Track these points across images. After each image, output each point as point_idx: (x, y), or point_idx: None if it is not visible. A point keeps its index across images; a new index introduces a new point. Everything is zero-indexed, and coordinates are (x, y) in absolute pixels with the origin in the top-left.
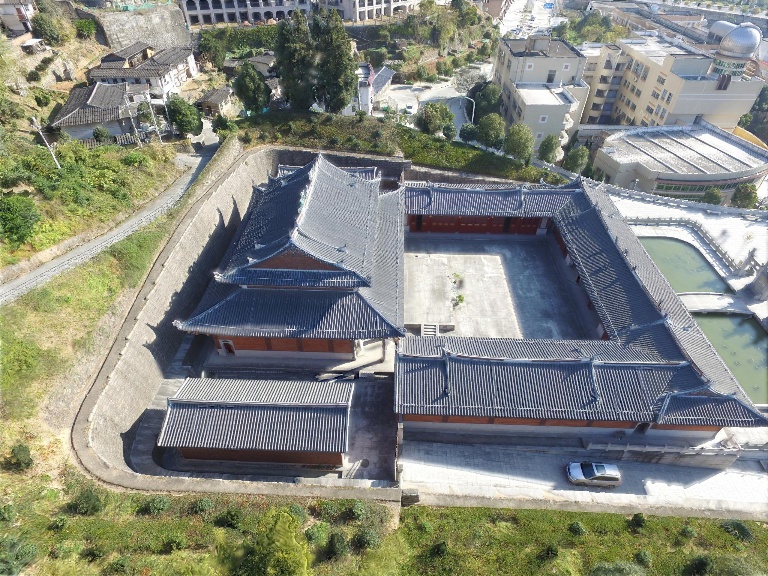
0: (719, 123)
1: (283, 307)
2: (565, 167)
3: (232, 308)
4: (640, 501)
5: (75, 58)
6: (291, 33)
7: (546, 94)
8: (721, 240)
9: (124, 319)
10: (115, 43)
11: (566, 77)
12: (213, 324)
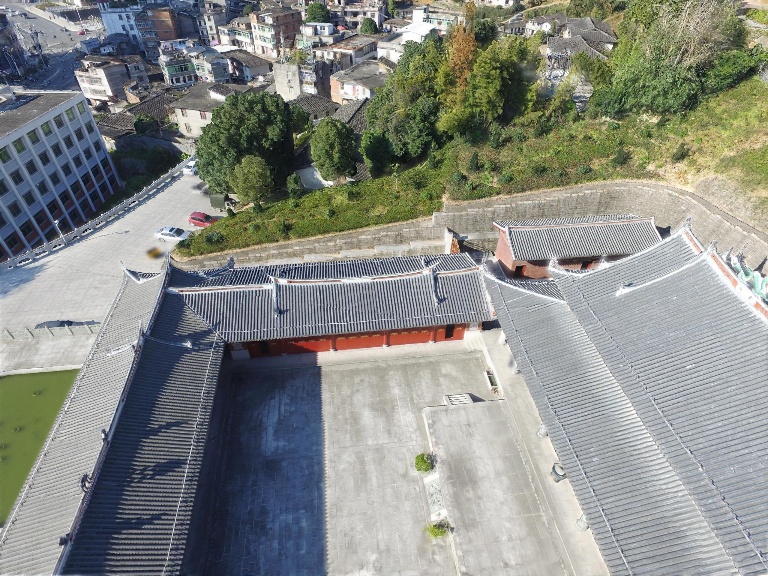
0: None
1: None
2: None
3: None
4: (266, 264)
5: None
6: None
7: None
8: None
9: None
10: None
11: None
12: None
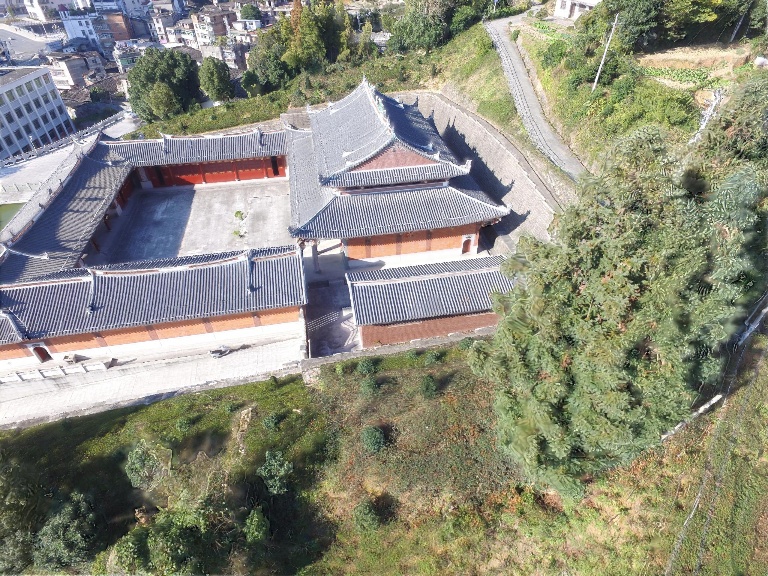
0: None
1: None
2: None
3: None
4: None
5: None
6: None
7: None
8: None
9: None
10: None
11: None
12: None
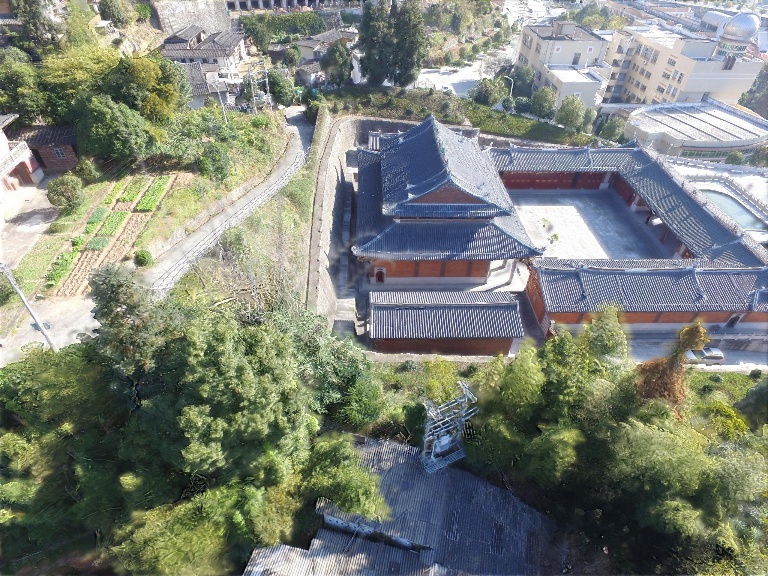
0: (723, 100)
1: (434, 237)
2: (602, 137)
3: (391, 238)
4: None
5: (137, 40)
6: (375, 13)
7: (575, 74)
8: None
9: (309, 246)
10: (167, 27)
11: (589, 59)
12: (379, 251)
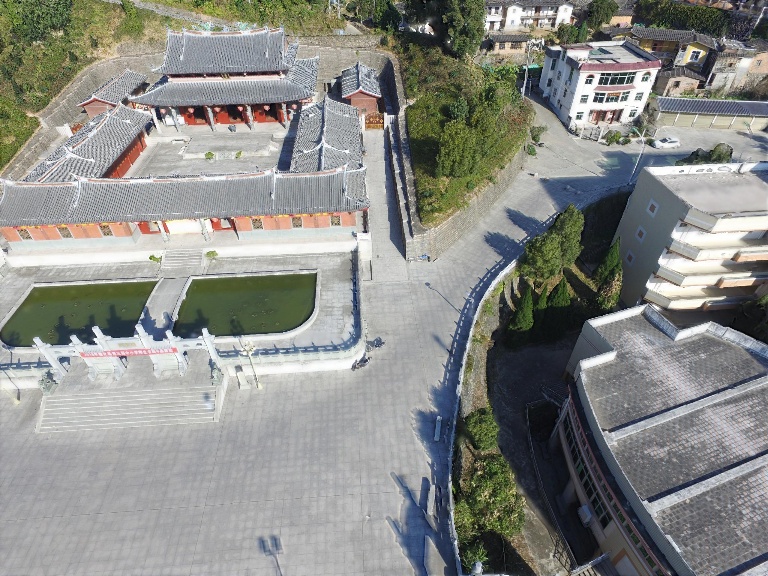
0: None
1: None
2: None
3: None
4: None
5: None
6: None
7: (763, 201)
8: (339, 405)
9: None
10: None
11: None
12: None
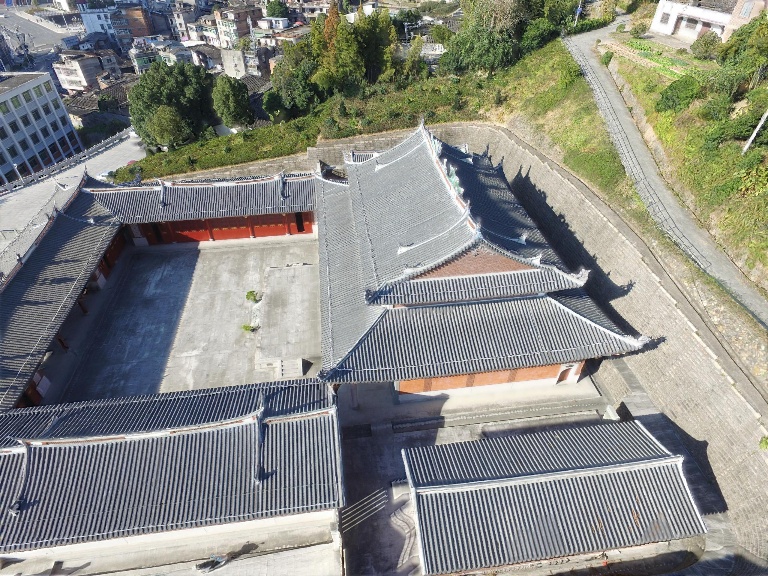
0: None
1: None
2: None
3: None
4: None
5: None
6: None
7: None
8: None
9: None
10: None
11: None
12: None
